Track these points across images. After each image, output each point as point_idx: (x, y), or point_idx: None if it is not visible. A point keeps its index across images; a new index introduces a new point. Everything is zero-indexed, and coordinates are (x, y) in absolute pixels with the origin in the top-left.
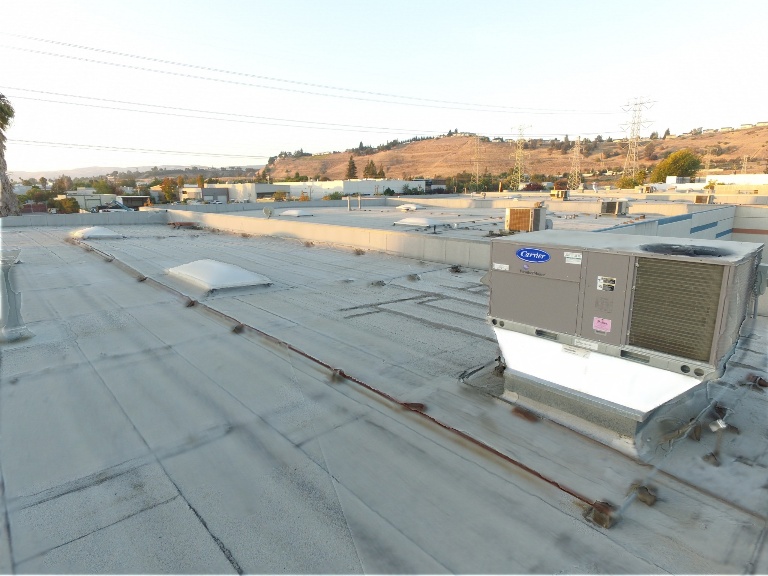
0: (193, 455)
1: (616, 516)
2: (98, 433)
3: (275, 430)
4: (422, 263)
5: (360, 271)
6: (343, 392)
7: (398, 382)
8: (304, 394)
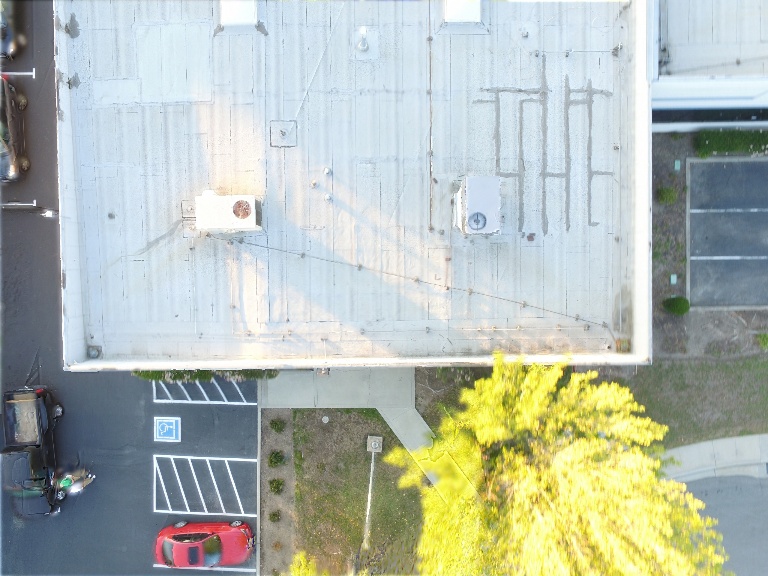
0: (386, 166)
1: None
2: (373, 143)
3: (403, 168)
4: (621, 8)
5: (558, 6)
6: (427, 162)
7: (443, 167)
8: (418, 157)
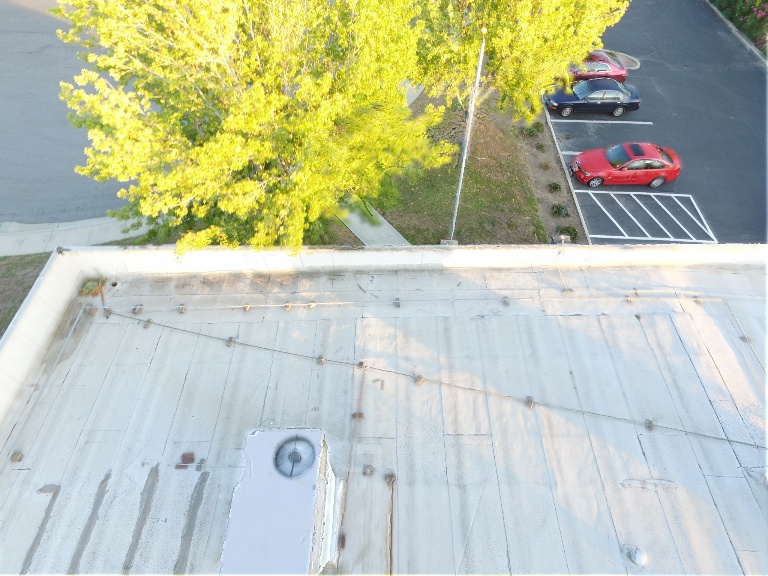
0: None
1: (393, 469)
2: None
3: None
4: None
5: None
6: None
7: None
8: None
